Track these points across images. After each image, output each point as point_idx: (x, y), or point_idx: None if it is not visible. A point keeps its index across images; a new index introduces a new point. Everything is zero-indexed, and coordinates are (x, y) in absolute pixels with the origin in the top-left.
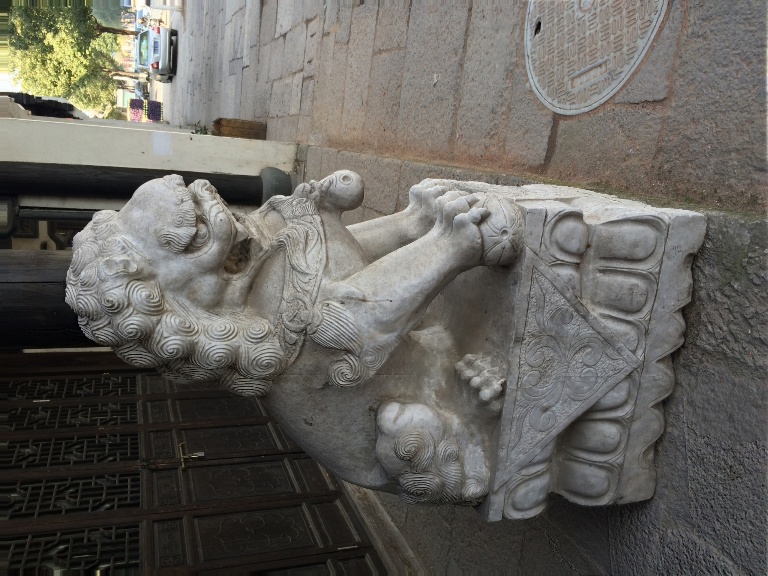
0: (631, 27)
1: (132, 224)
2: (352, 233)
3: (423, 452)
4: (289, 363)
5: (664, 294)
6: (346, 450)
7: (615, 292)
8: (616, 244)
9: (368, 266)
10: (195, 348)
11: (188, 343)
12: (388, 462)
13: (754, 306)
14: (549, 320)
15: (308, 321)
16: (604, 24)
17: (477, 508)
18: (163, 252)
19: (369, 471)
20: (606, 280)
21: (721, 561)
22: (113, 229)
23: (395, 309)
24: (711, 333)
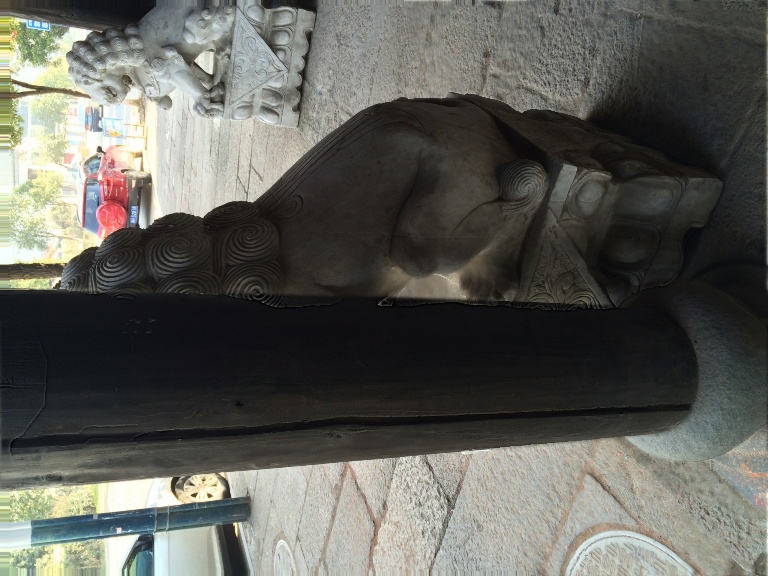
0: (608, 573)
1: None
2: None
3: None
4: None
5: None
6: None
7: None
8: None
9: None
10: None
11: None
12: None
13: None
14: None
15: None
16: None
17: None
18: None
19: None
20: None
21: (546, 91)
22: None
23: None
24: None
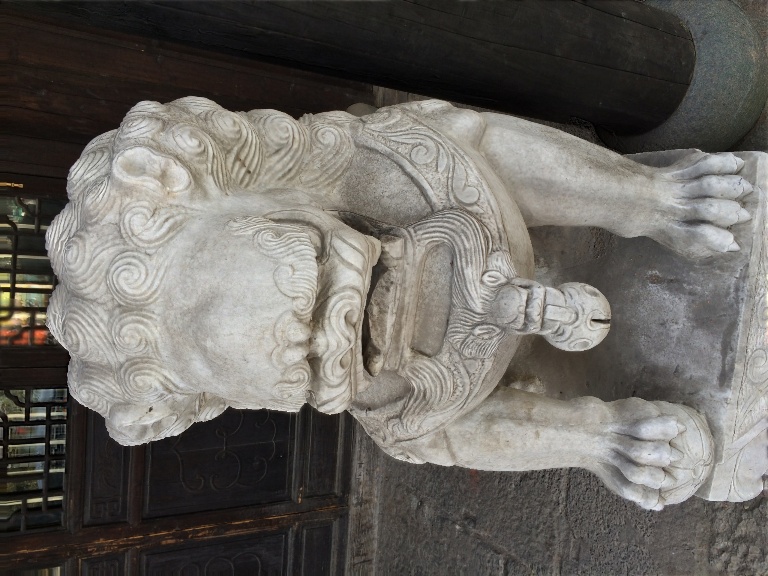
0: None
1: (187, 373)
2: (559, 193)
3: None
4: None
5: None
6: None
7: None
8: None
9: (492, 432)
10: None
11: None
12: None
13: None
14: None
15: (377, 443)
16: None
17: None
18: None
19: None
20: None
21: None
22: (150, 353)
23: None
24: None
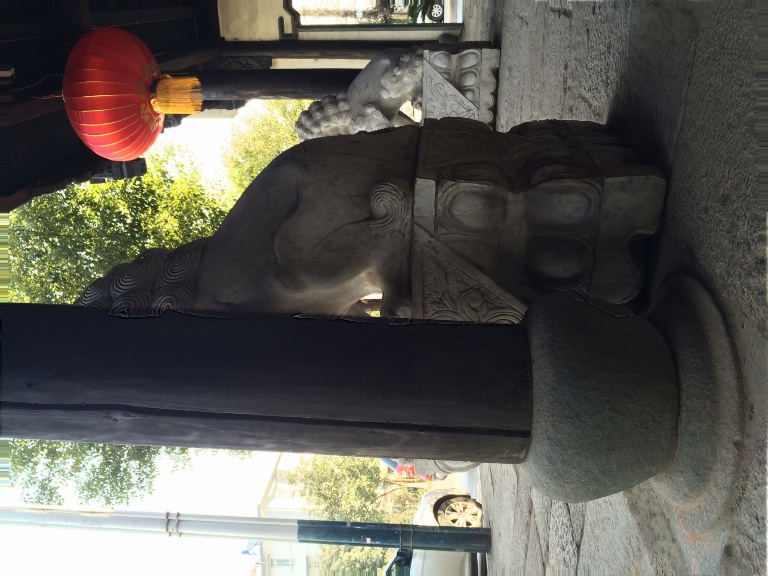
0: None
1: None
2: None
3: None
4: None
5: None
6: None
7: None
8: None
9: None
10: None
11: None
12: None
13: None
14: None
15: None
16: None
17: None
18: None
19: None
20: None
21: None
22: None
23: None
24: None
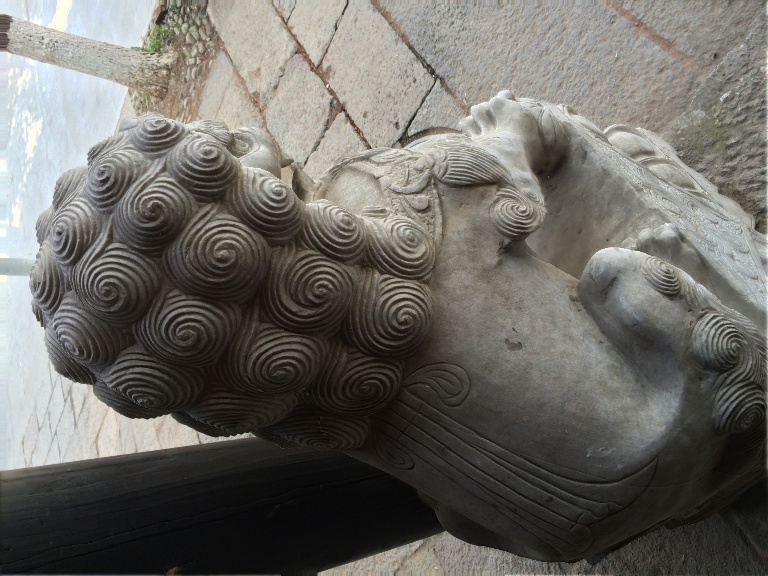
0: None
1: None
2: None
3: (683, 277)
4: (437, 239)
5: None
6: (592, 378)
7: (662, 173)
8: (623, 145)
9: None
10: (306, 211)
11: None
12: (660, 312)
13: (762, 129)
14: (642, 177)
15: (430, 162)
16: None
17: None
18: None
19: (646, 407)
20: None
21: None
22: None
23: (509, 143)
24: (761, 185)
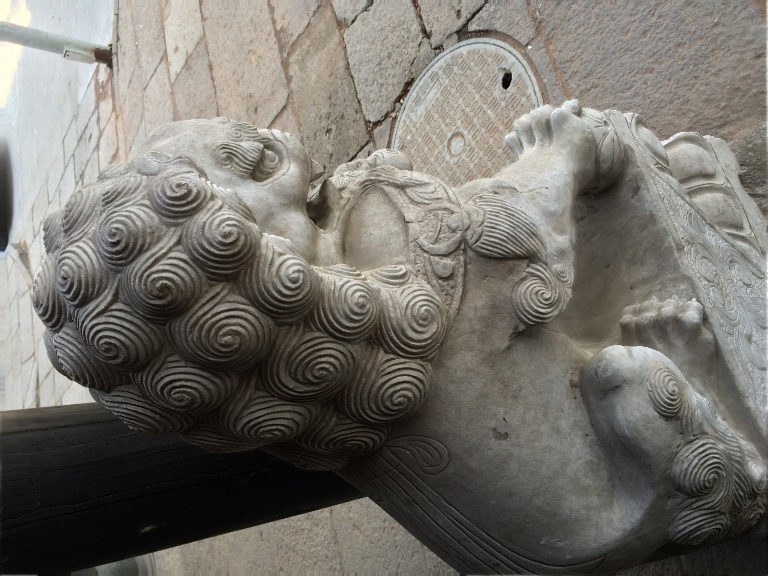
0: None
1: (163, 150)
2: None
3: (687, 395)
4: (452, 314)
5: (748, 210)
6: (567, 475)
7: (714, 207)
8: (685, 162)
9: None
10: (321, 288)
11: (312, 272)
12: (651, 433)
13: None
14: (689, 226)
15: (465, 224)
16: (486, 148)
17: (762, 527)
18: (223, 173)
19: (609, 508)
20: (697, 200)
21: None
22: None
23: (556, 197)
24: None
